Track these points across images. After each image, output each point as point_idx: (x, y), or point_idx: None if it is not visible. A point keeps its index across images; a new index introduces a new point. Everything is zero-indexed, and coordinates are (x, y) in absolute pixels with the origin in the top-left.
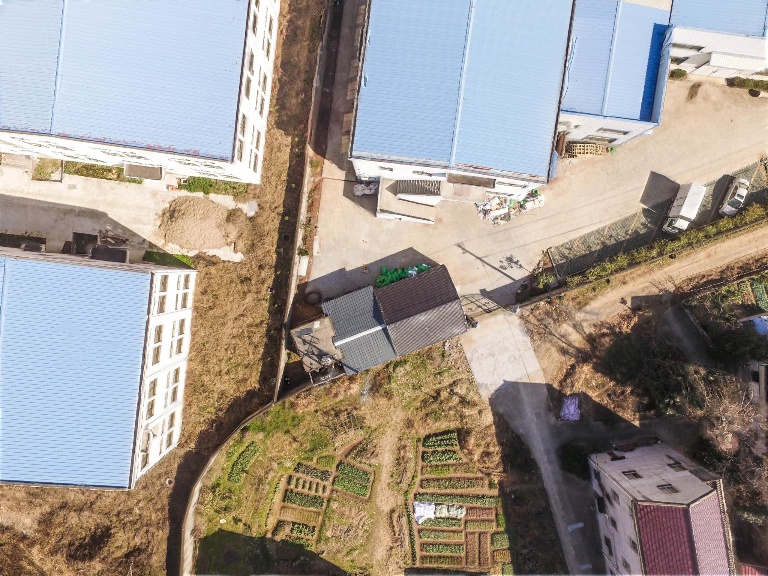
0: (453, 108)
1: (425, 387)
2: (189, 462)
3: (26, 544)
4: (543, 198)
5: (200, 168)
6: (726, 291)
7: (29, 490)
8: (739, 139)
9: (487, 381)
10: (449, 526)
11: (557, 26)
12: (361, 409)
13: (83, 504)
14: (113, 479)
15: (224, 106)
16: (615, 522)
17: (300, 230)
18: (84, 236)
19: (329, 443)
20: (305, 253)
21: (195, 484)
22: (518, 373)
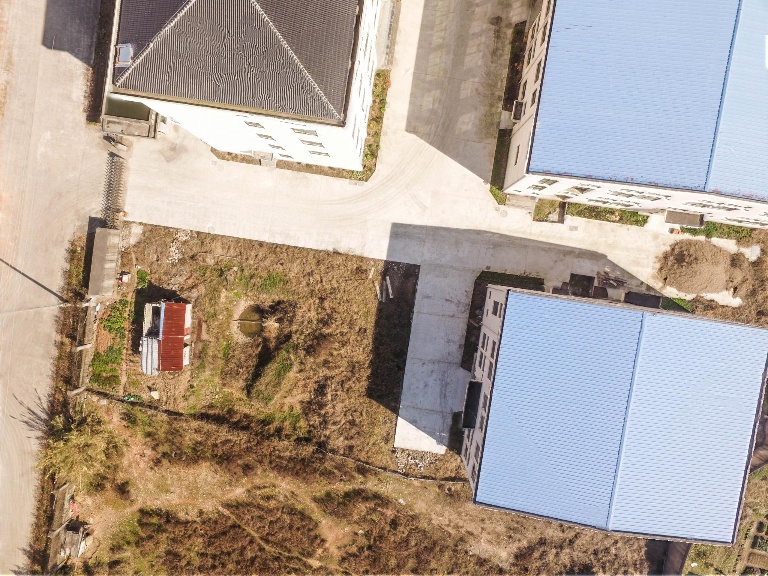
0: None
1: None
2: None
3: None
4: None
5: None
6: None
7: (509, 525)
8: None
9: None
10: None
11: None
12: None
13: (562, 541)
14: (718, 534)
15: None
16: None
17: None
18: (575, 277)
19: None
20: None
21: None
22: None
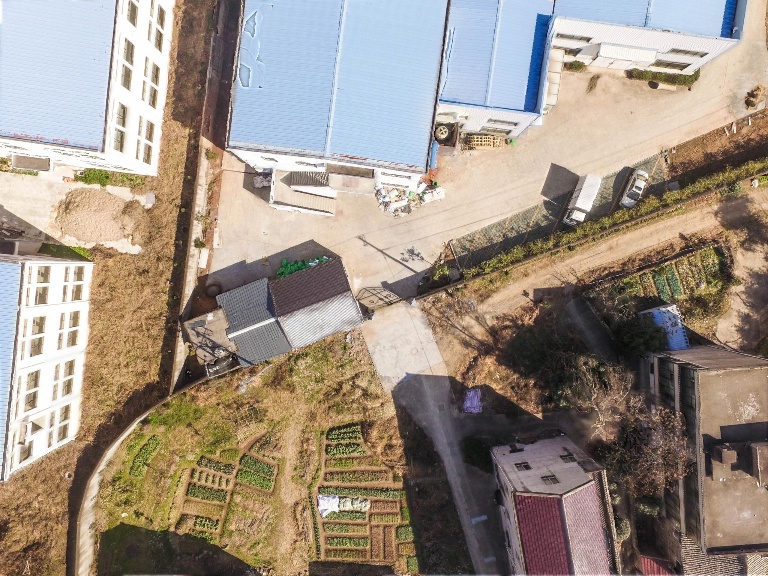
0: (325, 97)
1: (328, 380)
2: (88, 455)
3: None
4: (441, 190)
5: (83, 159)
6: (625, 283)
7: None
8: (639, 131)
9: (389, 374)
10: (353, 519)
11: (433, 16)
12: (263, 402)
13: None
14: None
15: (91, 95)
16: (508, 514)
17: (197, 222)
18: None
19: (232, 436)
20: (201, 245)
21: (90, 477)
22: (420, 366)
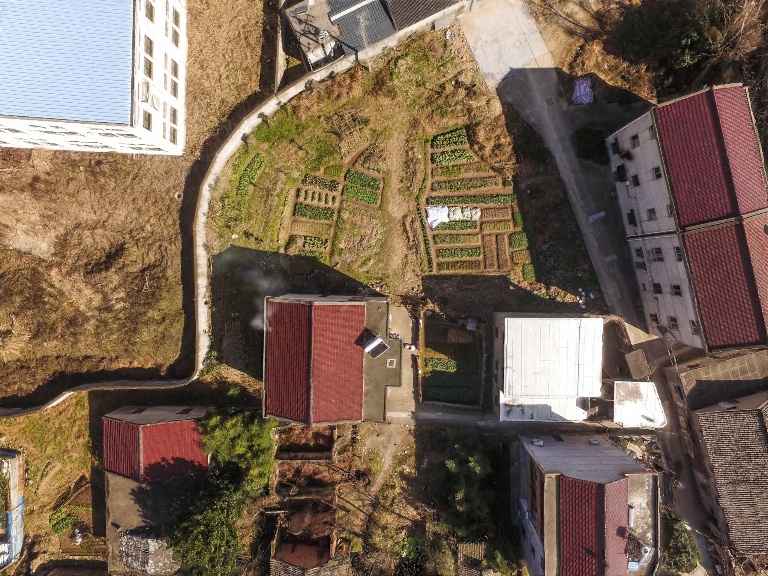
0: None
1: (429, 83)
2: (196, 174)
3: (44, 267)
4: None
5: None
6: None
7: (43, 213)
8: None
9: (493, 70)
10: (464, 228)
11: None
12: (365, 111)
13: (96, 224)
14: (114, 116)
15: None
16: (636, 175)
17: None
18: None
19: (335, 151)
20: None
21: (202, 182)
22: (525, 58)
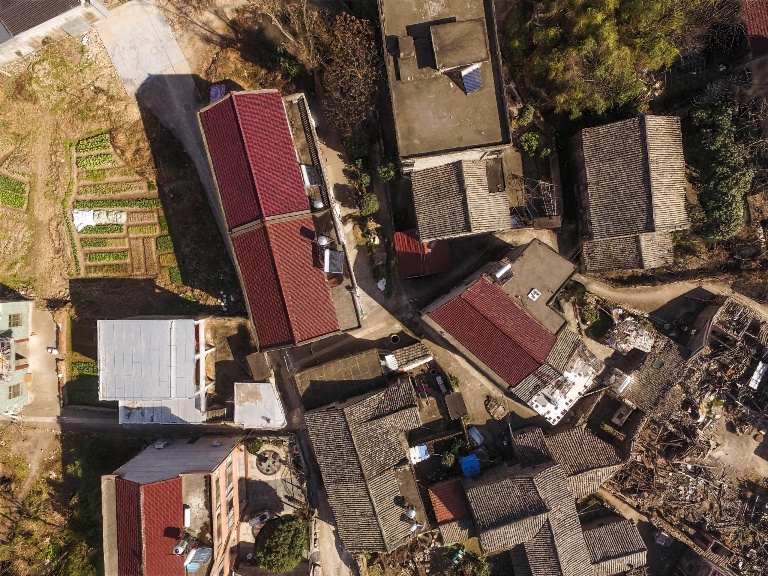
0: None
1: (70, 88)
2: None
3: None
4: None
5: None
6: None
7: None
8: None
9: (131, 76)
10: (109, 232)
11: None
12: (6, 115)
13: None
14: None
15: None
16: None
17: None
18: None
19: None
20: None
21: None
22: (162, 65)
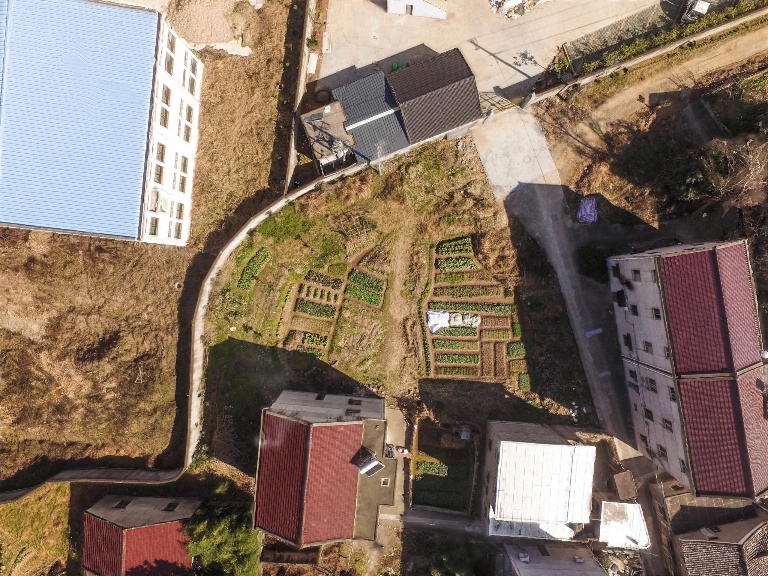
0: None
1: (438, 190)
2: (198, 265)
3: (34, 349)
4: None
5: None
6: None
7: (36, 294)
8: None
9: (502, 183)
10: (464, 335)
11: None
12: (373, 213)
13: (91, 308)
14: (122, 228)
15: None
16: (636, 306)
17: (309, 20)
18: None
19: (340, 249)
20: (314, 42)
21: (205, 278)
22: (533, 174)
